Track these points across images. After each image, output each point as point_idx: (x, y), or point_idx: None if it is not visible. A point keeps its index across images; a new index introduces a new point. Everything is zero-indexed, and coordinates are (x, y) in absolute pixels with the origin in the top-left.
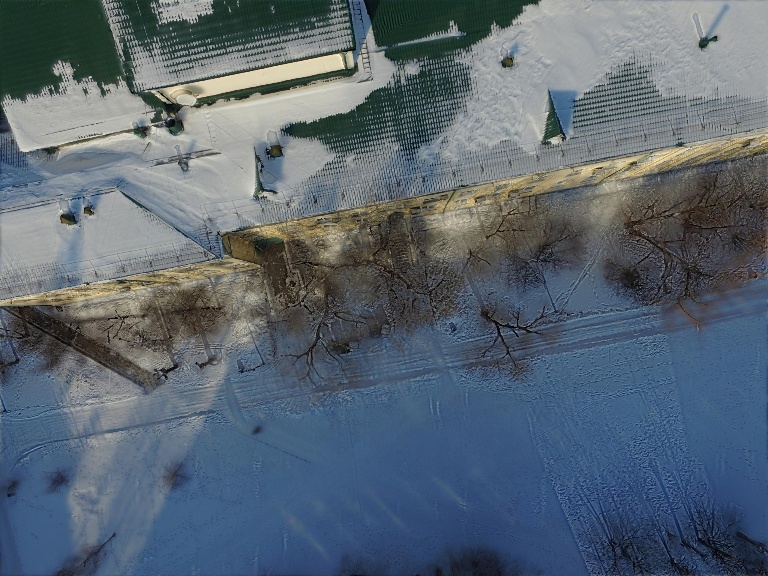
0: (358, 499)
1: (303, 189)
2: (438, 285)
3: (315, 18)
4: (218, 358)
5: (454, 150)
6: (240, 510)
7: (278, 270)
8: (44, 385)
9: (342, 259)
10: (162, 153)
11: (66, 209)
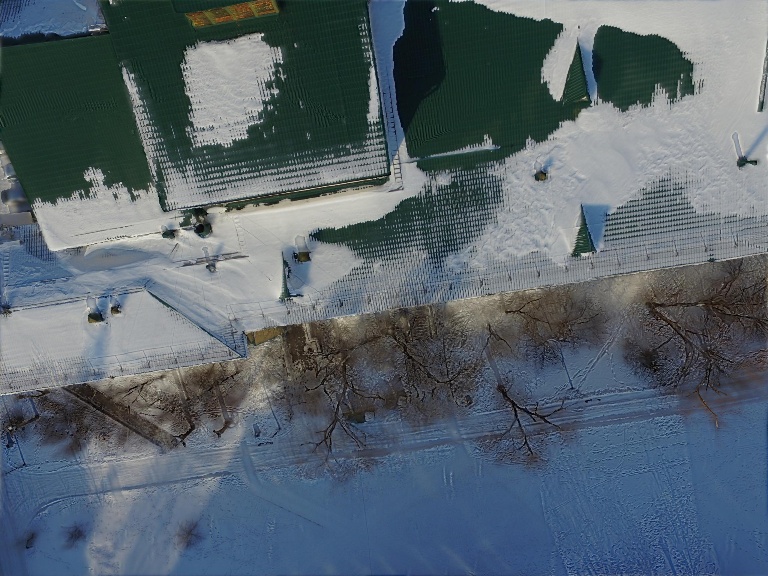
0: (369, 564)
1: (329, 293)
2: (458, 374)
3: (350, 145)
4: (235, 421)
5: (483, 260)
6: (253, 570)
7: (297, 338)
8: (63, 441)
9: (360, 328)
10: (190, 254)
11: (93, 307)
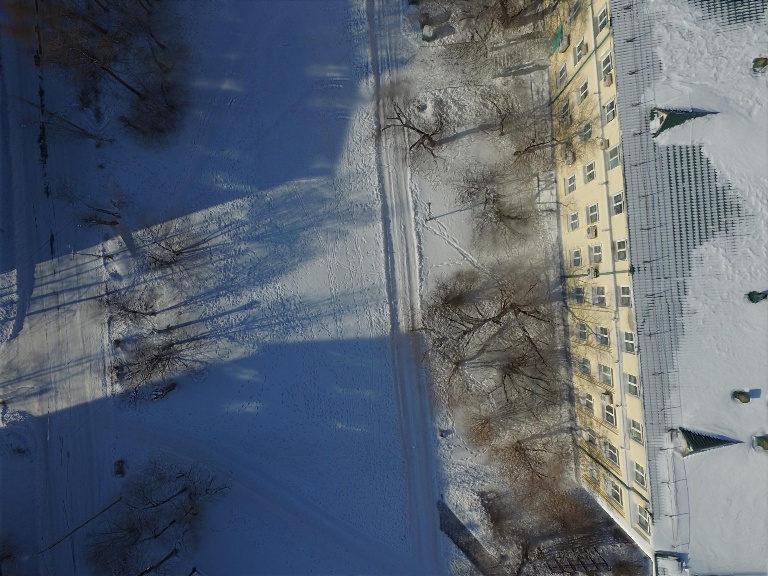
0: None
1: None
2: None
3: None
4: None
5: (657, 6)
6: None
7: None
8: None
9: None
10: None
11: None
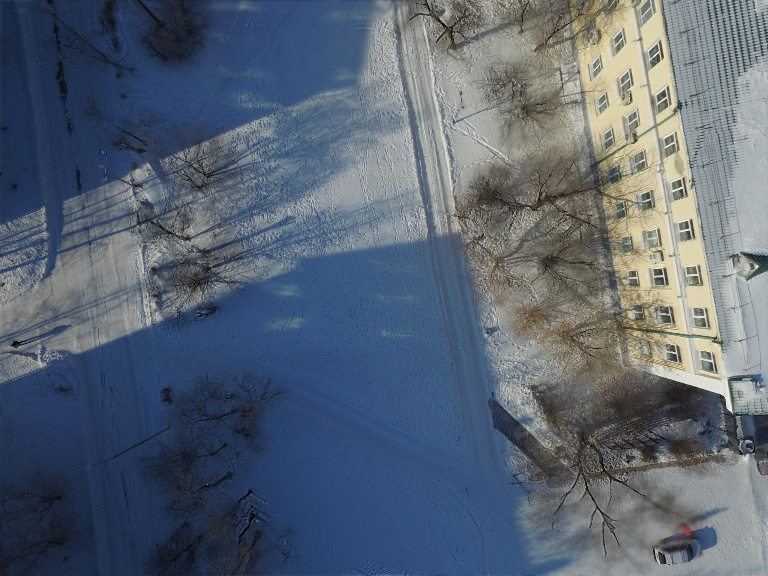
0: None
1: None
2: None
3: None
4: None
5: None
6: None
7: None
8: None
9: None
10: None
11: None
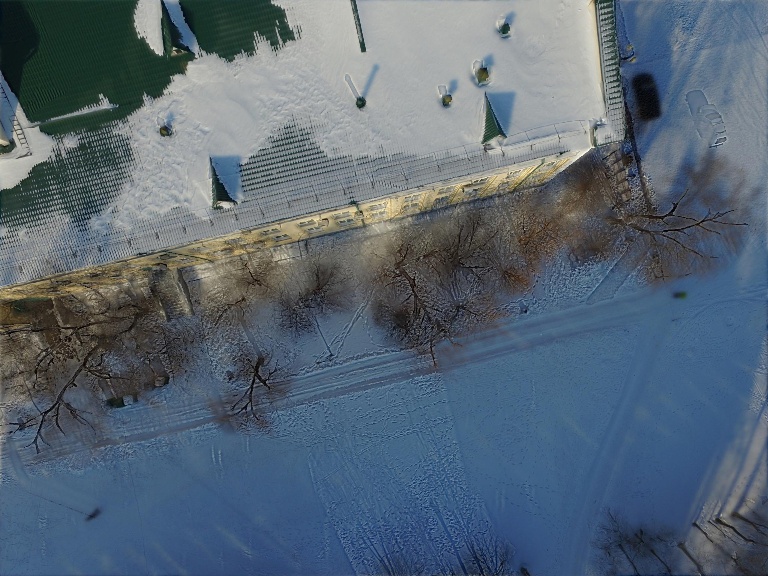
0: (143, 552)
1: None
2: None
3: None
4: None
5: (126, 219)
6: (27, 569)
7: None
8: None
9: (118, 312)
10: None
11: None
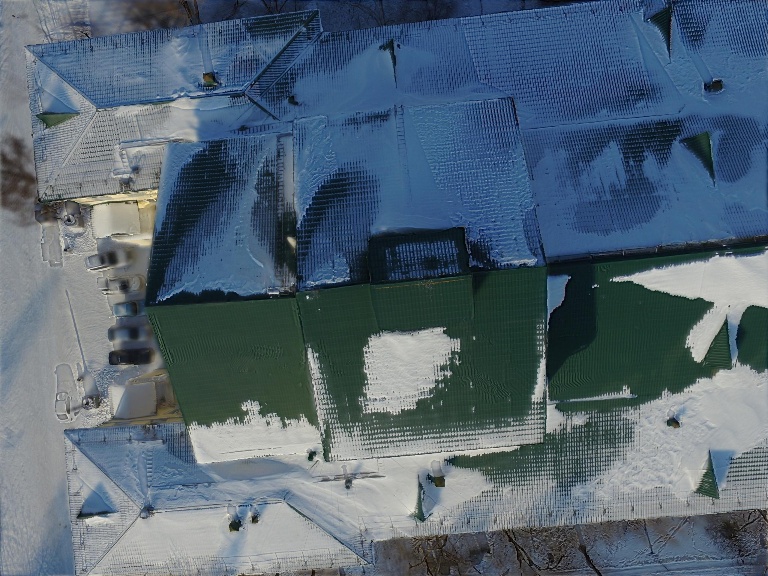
0: None
1: (458, 511)
2: None
3: (512, 418)
4: None
5: (608, 491)
6: None
7: None
8: None
9: None
10: (329, 470)
11: (233, 513)
